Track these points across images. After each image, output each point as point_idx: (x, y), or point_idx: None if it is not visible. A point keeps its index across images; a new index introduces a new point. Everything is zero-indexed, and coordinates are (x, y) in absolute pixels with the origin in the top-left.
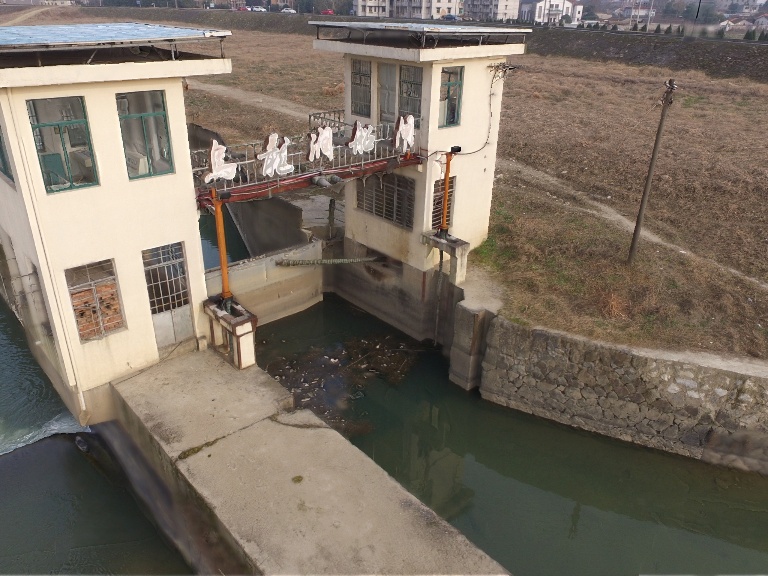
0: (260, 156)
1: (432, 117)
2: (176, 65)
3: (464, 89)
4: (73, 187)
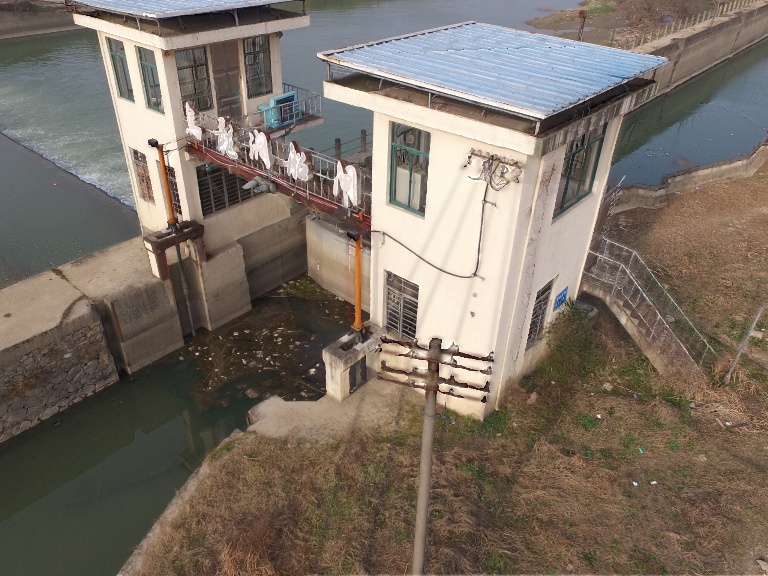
0: (215, 132)
1: (377, 183)
2: (138, 34)
3: (431, 168)
4: (129, 98)
